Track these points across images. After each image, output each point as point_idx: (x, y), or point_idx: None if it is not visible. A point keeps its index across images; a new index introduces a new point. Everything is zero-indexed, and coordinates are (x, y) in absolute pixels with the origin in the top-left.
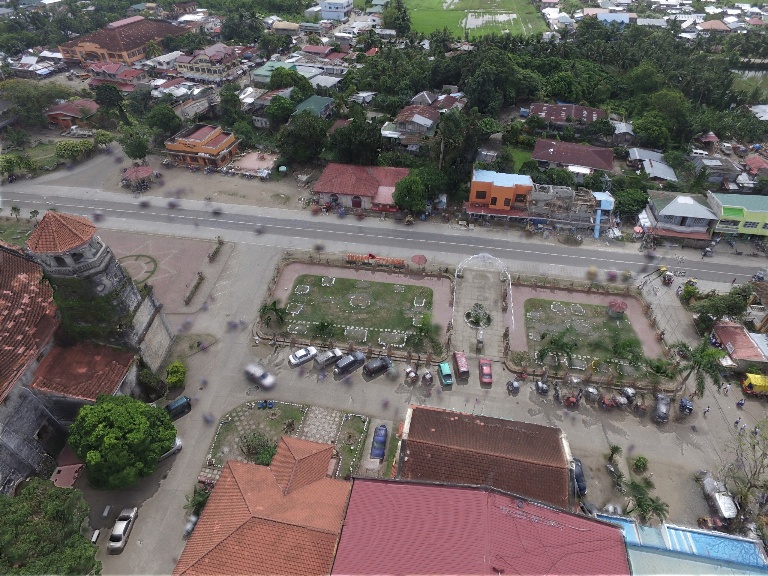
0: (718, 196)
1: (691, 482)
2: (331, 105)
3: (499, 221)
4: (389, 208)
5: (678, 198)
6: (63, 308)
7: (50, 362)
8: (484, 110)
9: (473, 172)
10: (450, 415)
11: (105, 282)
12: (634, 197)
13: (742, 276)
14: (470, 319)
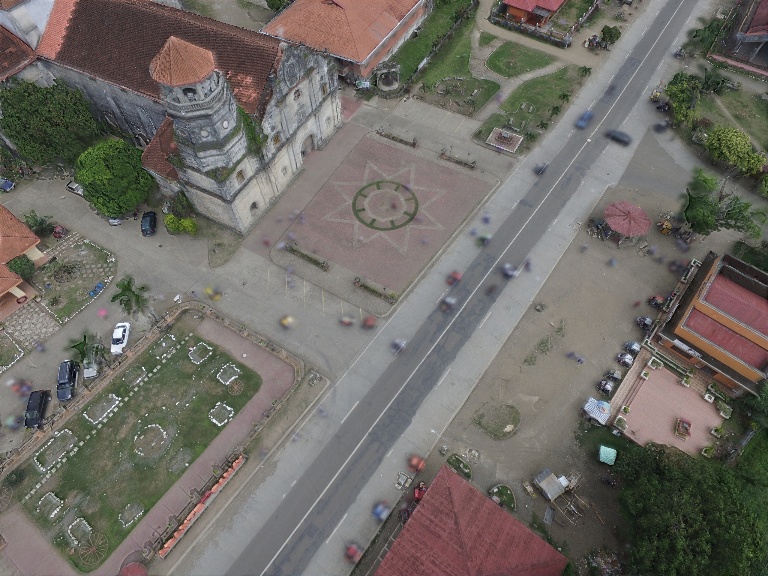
0: None
1: None
2: None
3: None
4: None
5: None
6: None
7: None
8: None
9: None
10: None
11: None
12: None
13: None
14: None
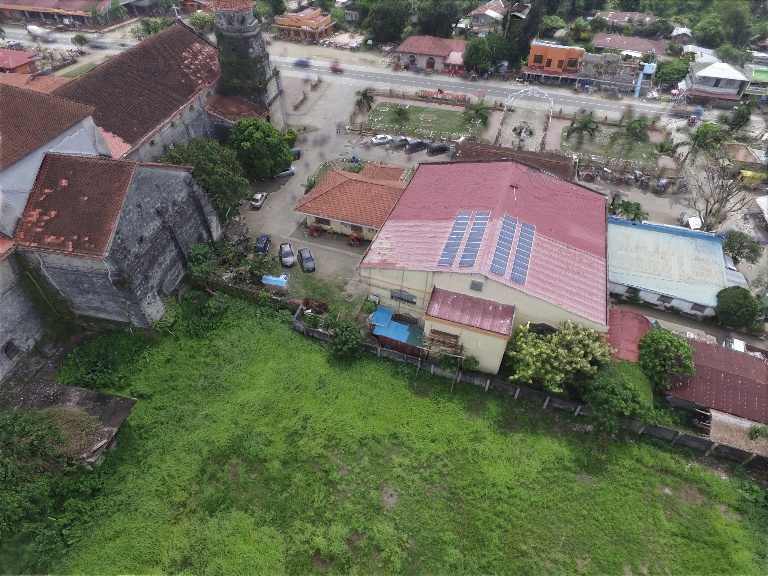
0: (754, 65)
1: (673, 220)
2: (413, 6)
3: (551, 84)
4: (457, 70)
5: (715, 64)
6: (224, 65)
7: (213, 100)
8: (552, 15)
9: (534, 40)
10: None
11: (254, 47)
12: (676, 67)
13: (761, 124)
14: (516, 132)
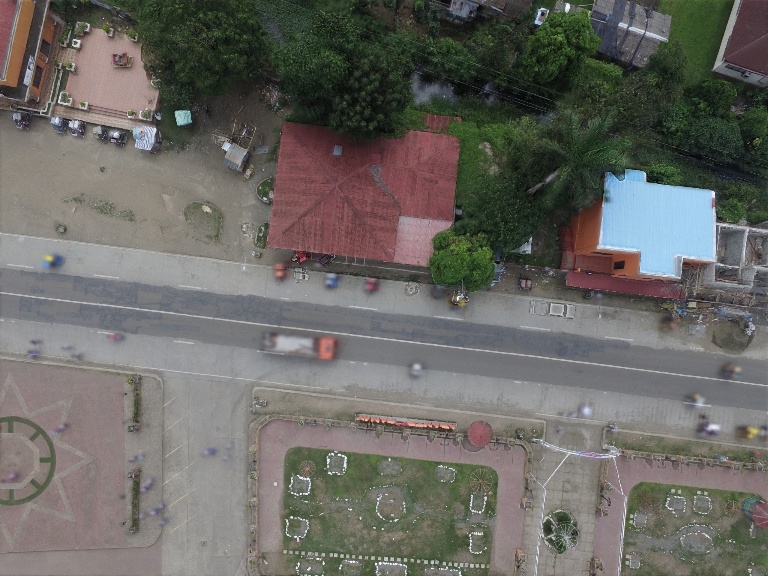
0: None
1: None
2: None
3: None
4: None
5: None
6: None
7: None
8: None
9: (602, 206)
10: None
11: None
12: None
13: None
14: (549, 536)
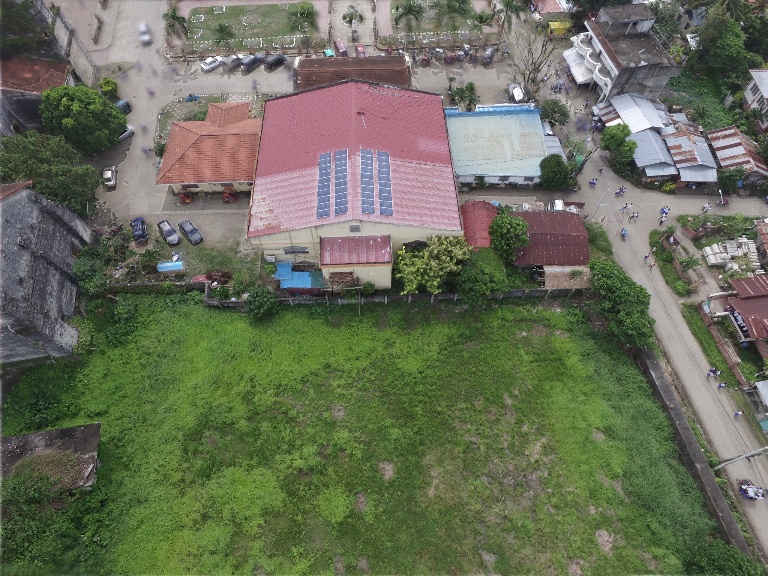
0: None
1: (501, 92)
2: None
3: None
4: None
5: None
6: None
7: None
8: None
9: None
10: (328, 59)
11: None
12: None
13: None
14: (346, 20)
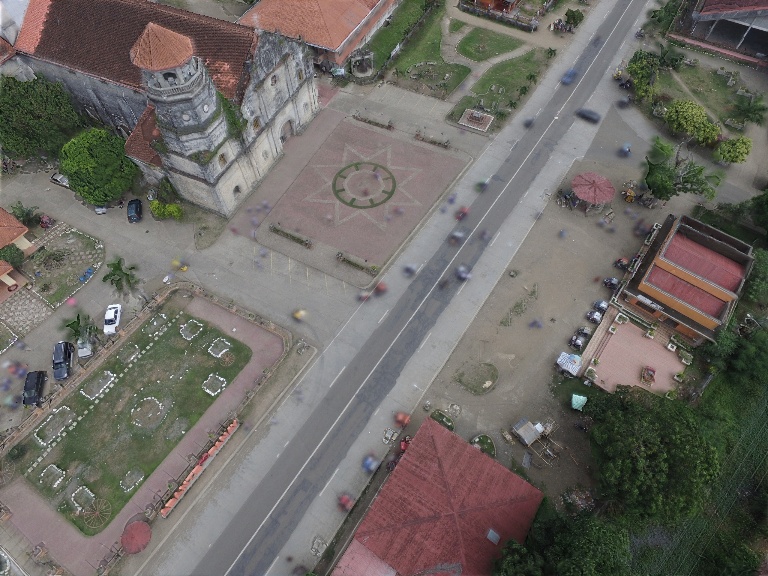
0: None
1: None
2: None
3: None
4: None
5: None
6: None
7: None
8: None
9: None
10: None
11: None
12: None
13: None
14: None
